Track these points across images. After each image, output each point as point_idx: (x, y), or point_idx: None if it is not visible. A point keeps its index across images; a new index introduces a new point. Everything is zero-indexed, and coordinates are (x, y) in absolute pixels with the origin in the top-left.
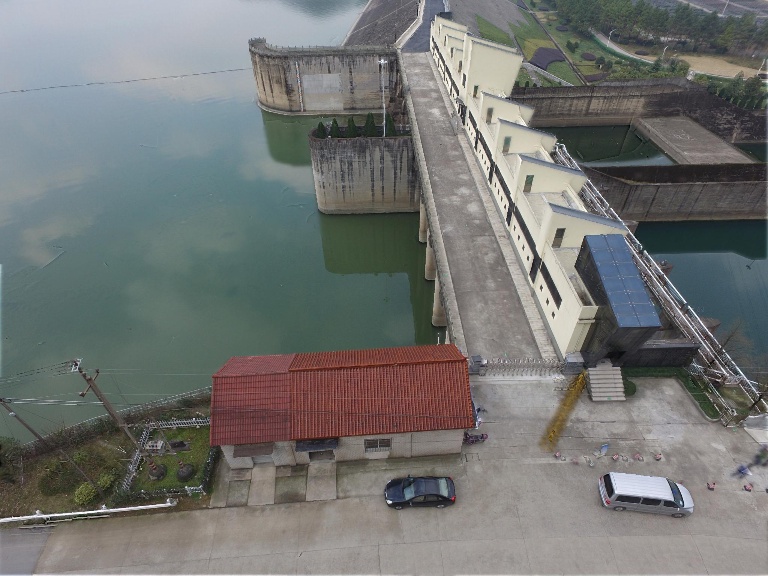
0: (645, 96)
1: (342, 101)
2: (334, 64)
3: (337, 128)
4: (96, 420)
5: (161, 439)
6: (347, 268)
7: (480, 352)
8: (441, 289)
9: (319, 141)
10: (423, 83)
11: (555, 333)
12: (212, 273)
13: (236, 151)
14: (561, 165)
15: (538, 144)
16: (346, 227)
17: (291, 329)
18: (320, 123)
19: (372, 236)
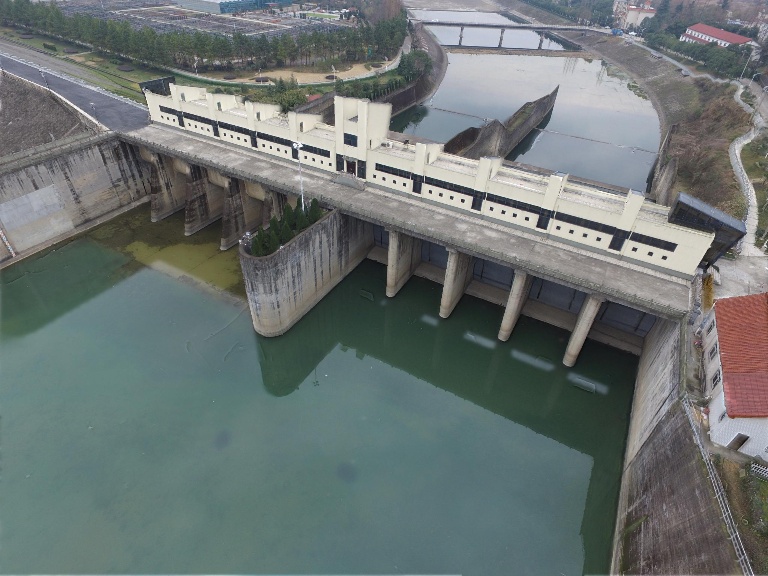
0: (322, 112)
1: (68, 218)
2: (39, 175)
3: (276, 234)
4: (765, 566)
5: (766, 520)
6: (299, 378)
7: (671, 304)
8: (596, 291)
9: (273, 258)
10: (227, 157)
11: (673, 267)
12: (291, 484)
13: (2, 358)
14: (557, 172)
15: (499, 166)
16: (297, 335)
17: (449, 440)
18: (256, 238)
19: (317, 327)
